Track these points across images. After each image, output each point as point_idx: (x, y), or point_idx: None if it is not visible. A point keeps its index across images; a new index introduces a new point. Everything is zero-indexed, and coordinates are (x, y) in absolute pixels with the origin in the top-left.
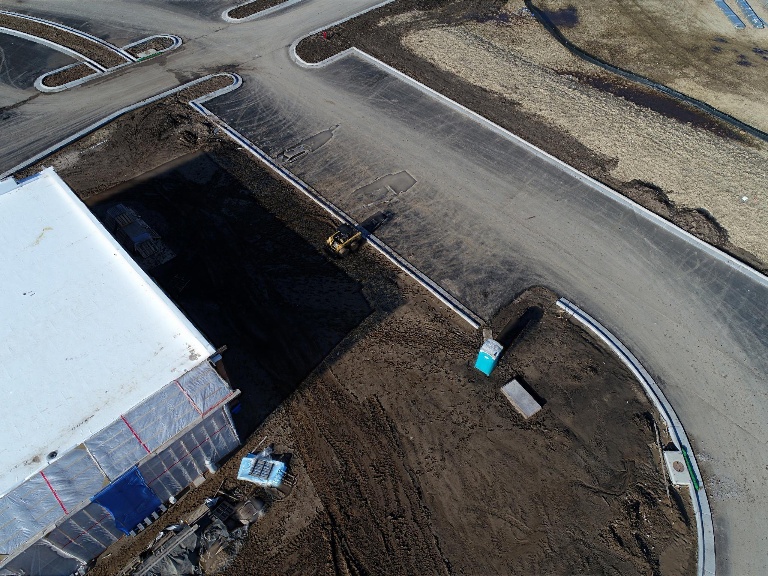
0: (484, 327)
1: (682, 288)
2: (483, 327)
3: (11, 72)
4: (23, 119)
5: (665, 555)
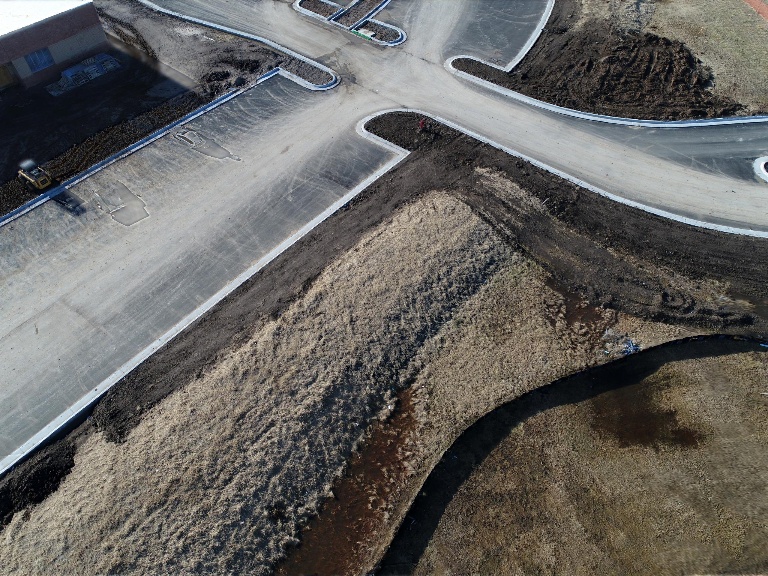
0: None
1: None
2: None
3: None
4: (252, 5)
5: None
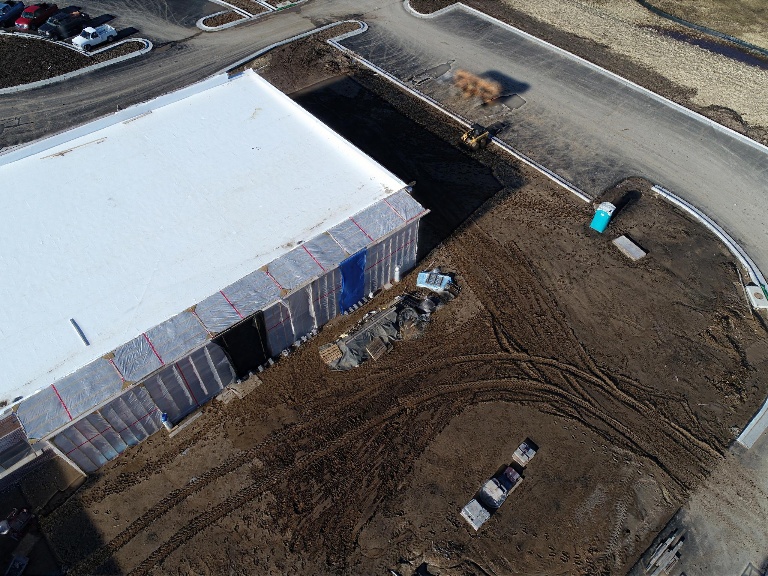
0: (594, 202)
1: (757, 182)
2: (593, 202)
3: (175, 16)
4: (194, 49)
5: (750, 349)
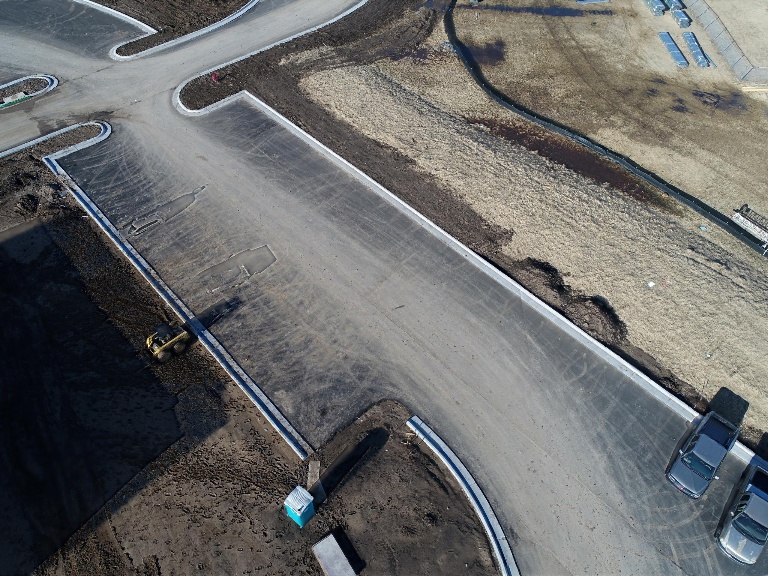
0: (312, 457)
1: (560, 403)
2: (311, 457)
3: None
4: None
5: None
